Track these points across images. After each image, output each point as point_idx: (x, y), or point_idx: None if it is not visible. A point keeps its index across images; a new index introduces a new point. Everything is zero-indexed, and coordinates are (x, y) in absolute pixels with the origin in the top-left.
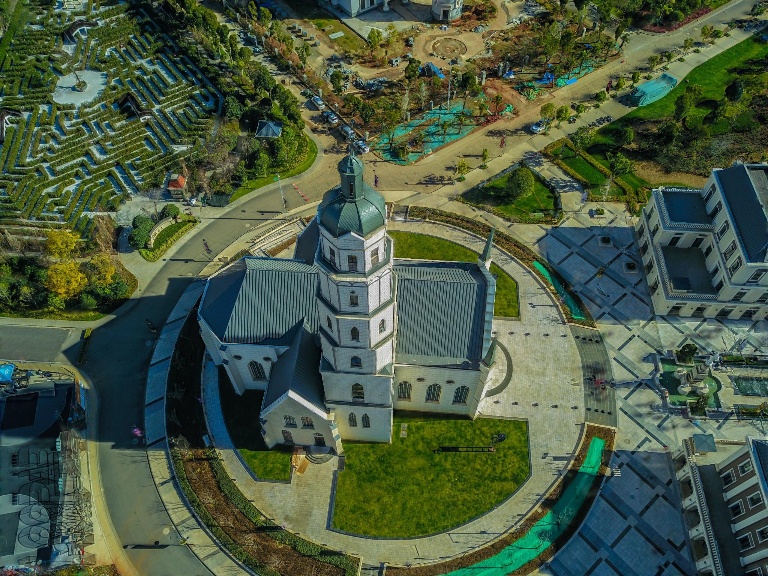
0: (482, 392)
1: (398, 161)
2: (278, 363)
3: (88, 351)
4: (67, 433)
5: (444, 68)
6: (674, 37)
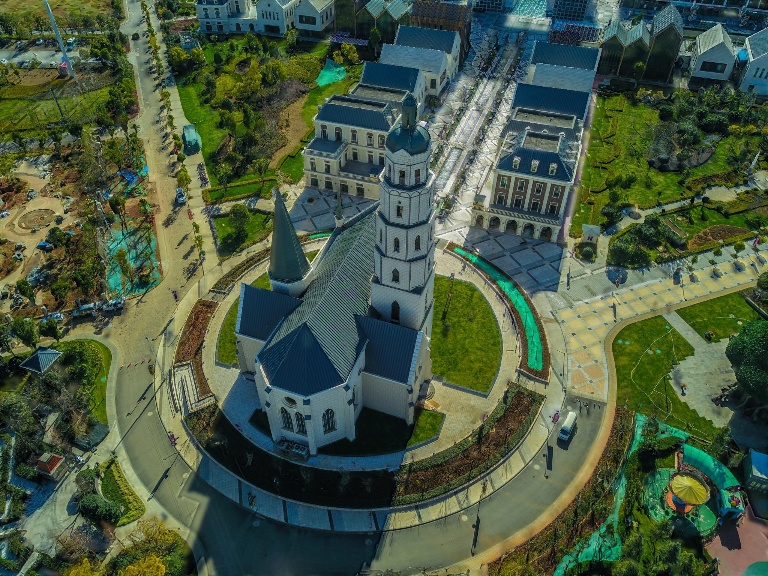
0: None
1: (152, 285)
2: (371, 359)
3: None
4: (361, 575)
5: (61, 228)
6: (146, 113)
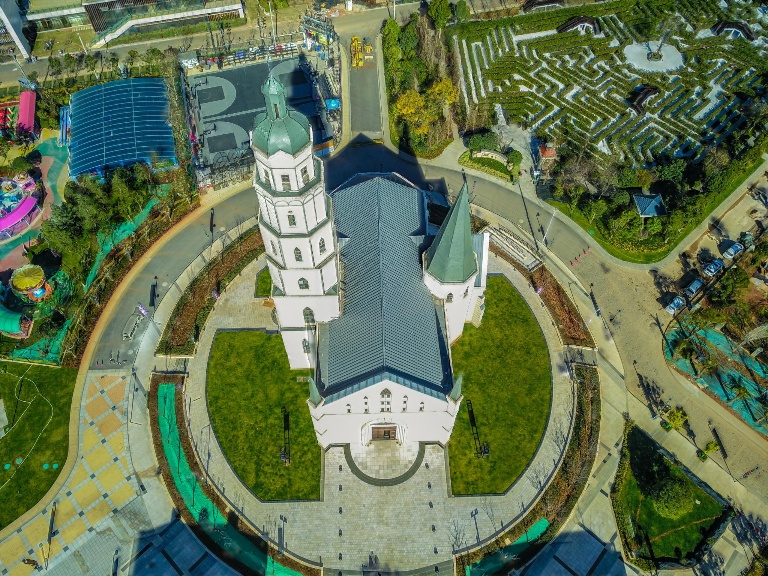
0: (313, 421)
1: (669, 349)
2: None
3: (364, 147)
4: None
5: None
6: None
